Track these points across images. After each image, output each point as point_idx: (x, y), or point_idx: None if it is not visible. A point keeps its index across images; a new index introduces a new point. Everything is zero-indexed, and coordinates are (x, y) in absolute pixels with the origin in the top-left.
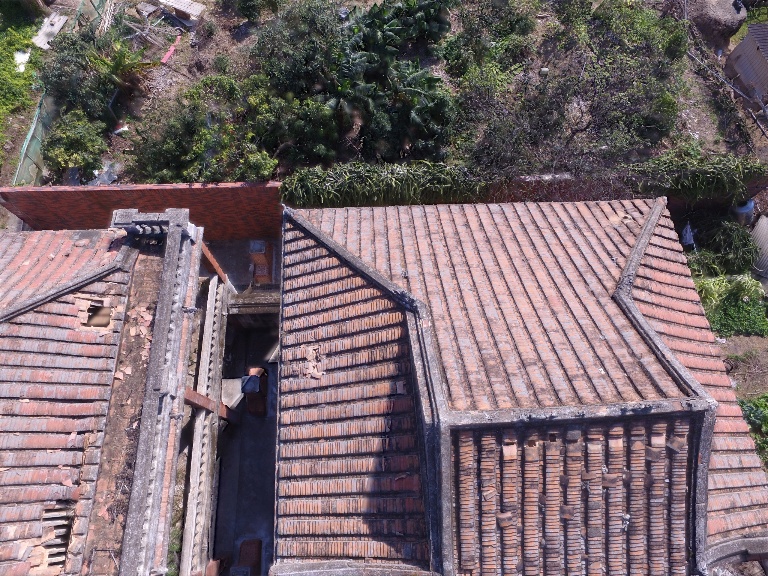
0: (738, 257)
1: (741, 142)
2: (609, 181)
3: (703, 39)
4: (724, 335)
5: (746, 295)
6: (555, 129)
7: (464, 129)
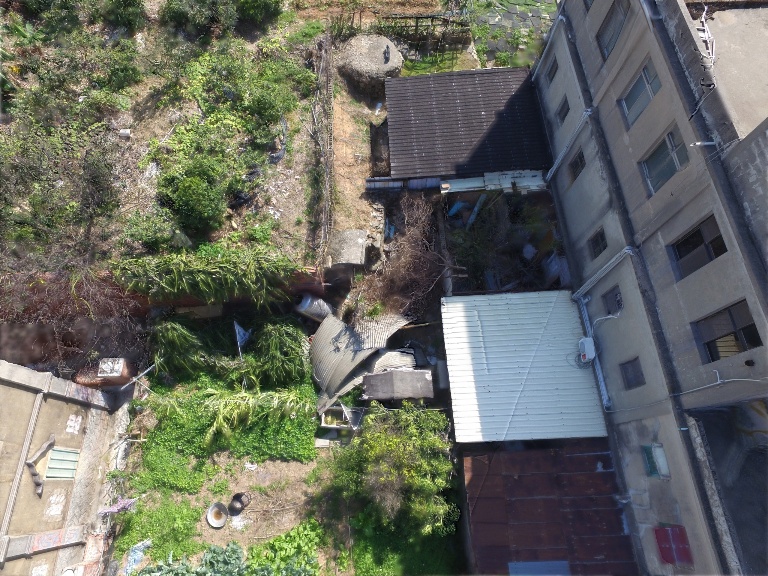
0: (273, 368)
1: (320, 224)
2: (72, 285)
3: (351, 92)
4: (254, 460)
5: (293, 411)
6: (101, 206)
7: (3, 203)
